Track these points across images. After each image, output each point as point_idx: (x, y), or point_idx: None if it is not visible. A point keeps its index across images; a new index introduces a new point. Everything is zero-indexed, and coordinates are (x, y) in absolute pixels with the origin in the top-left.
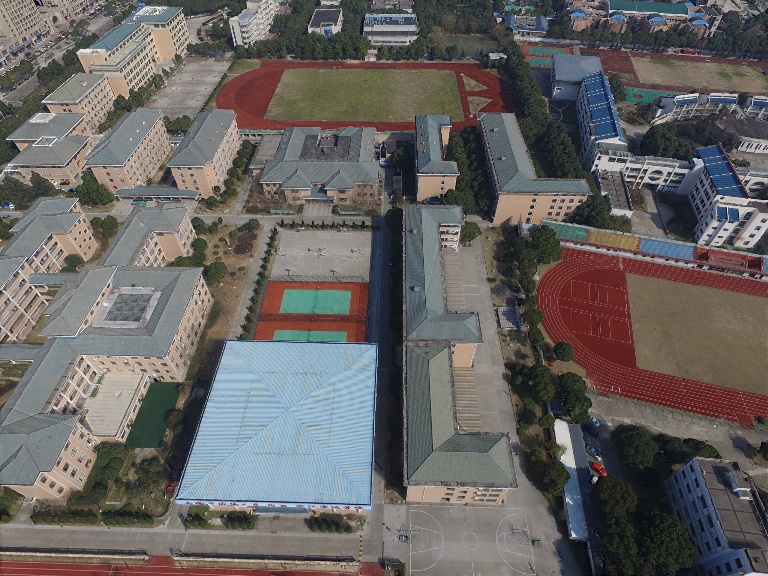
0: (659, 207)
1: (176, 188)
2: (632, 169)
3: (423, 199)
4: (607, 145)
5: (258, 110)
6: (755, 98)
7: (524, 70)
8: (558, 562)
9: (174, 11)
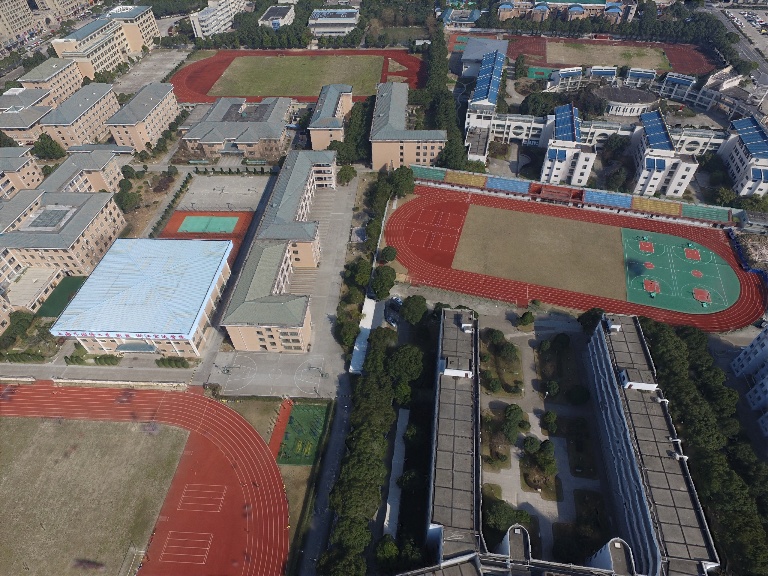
0: (520, 157)
1: (116, 145)
2: (498, 125)
3: None
4: (479, 106)
5: (203, 89)
6: (632, 70)
7: (439, 52)
8: (337, 387)
9: (143, 9)
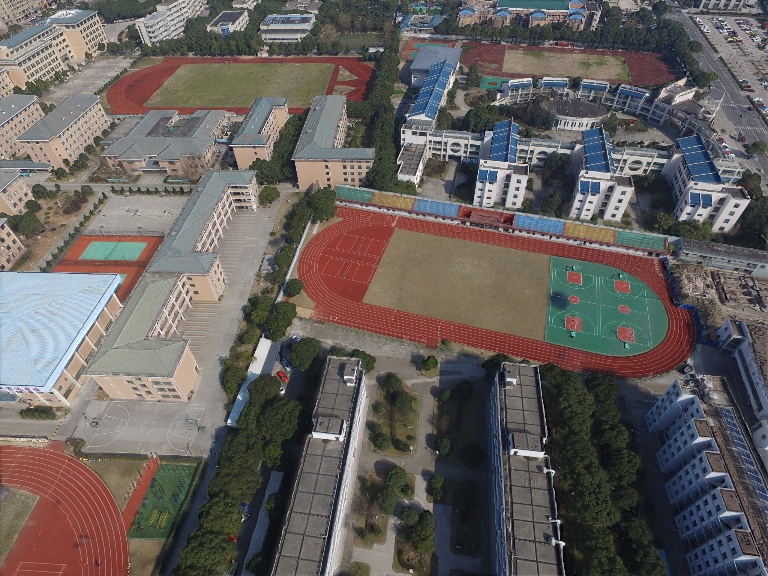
0: (457, 176)
1: (32, 161)
2: (435, 142)
3: (244, 169)
4: (415, 121)
5: (141, 99)
6: (584, 81)
7: (389, 61)
8: (212, 443)
9: (87, 14)
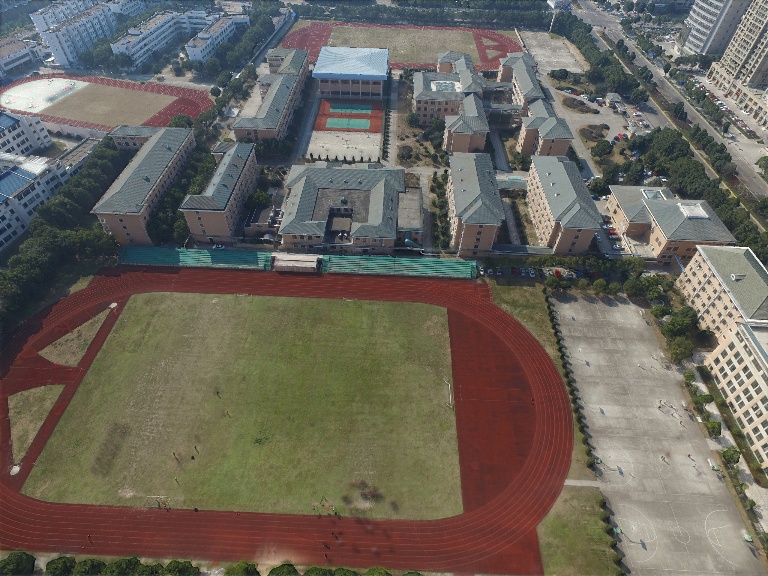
0: None
1: None
2: None
3: None
4: (34, 171)
5: (463, 329)
6: None
7: None
8: None
9: None
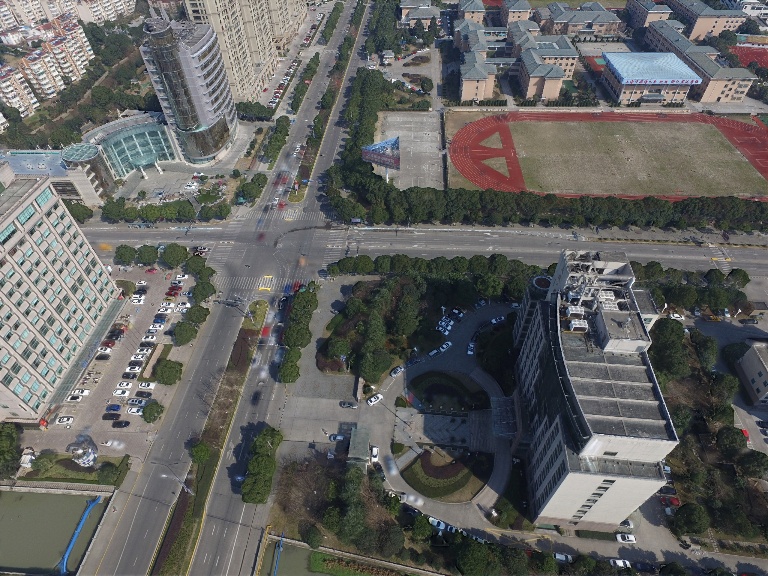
0: None
1: (505, 27)
2: (764, 14)
3: None
4: (748, 2)
5: None
6: None
7: None
8: None
9: None
